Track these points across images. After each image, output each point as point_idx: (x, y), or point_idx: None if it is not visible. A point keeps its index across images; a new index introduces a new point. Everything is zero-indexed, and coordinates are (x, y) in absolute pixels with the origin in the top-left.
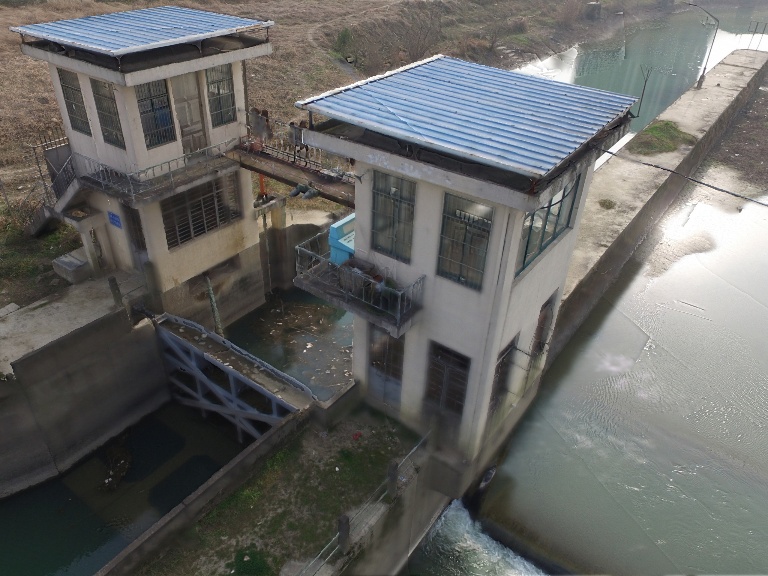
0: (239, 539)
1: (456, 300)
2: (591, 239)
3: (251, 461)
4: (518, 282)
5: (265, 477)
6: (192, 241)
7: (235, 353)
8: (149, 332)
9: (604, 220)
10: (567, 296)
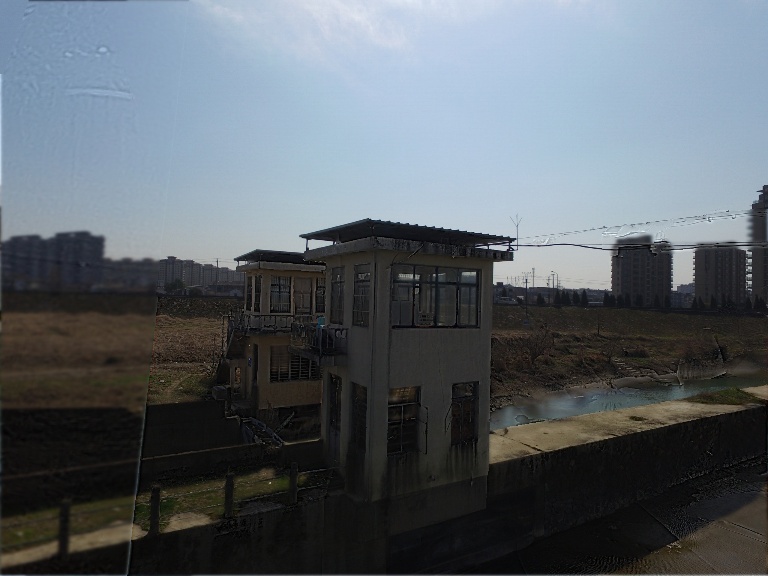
0: (172, 495)
1: (360, 340)
2: (603, 431)
3: (216, 460)
4: (401, 329)
5: (221, 476)
6: (288, 381)
7: (273, 440)
8: (235, 425)
9: (626, 424)
10: (550, 450)
